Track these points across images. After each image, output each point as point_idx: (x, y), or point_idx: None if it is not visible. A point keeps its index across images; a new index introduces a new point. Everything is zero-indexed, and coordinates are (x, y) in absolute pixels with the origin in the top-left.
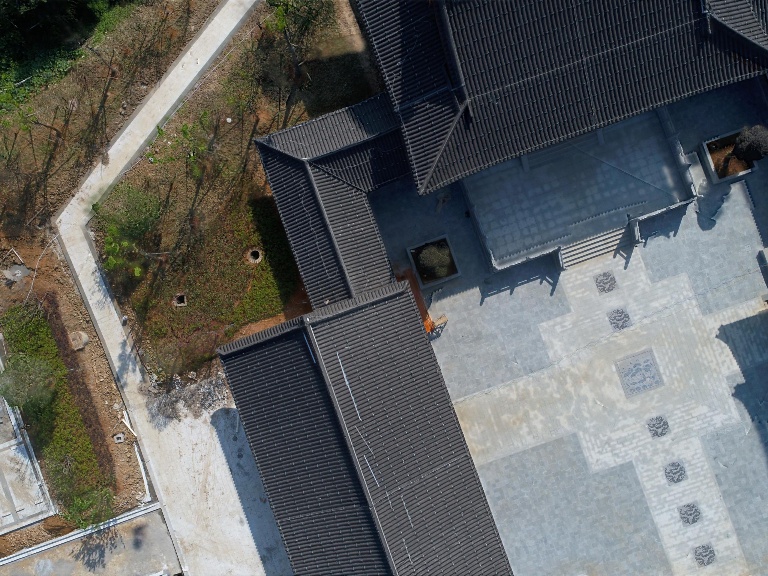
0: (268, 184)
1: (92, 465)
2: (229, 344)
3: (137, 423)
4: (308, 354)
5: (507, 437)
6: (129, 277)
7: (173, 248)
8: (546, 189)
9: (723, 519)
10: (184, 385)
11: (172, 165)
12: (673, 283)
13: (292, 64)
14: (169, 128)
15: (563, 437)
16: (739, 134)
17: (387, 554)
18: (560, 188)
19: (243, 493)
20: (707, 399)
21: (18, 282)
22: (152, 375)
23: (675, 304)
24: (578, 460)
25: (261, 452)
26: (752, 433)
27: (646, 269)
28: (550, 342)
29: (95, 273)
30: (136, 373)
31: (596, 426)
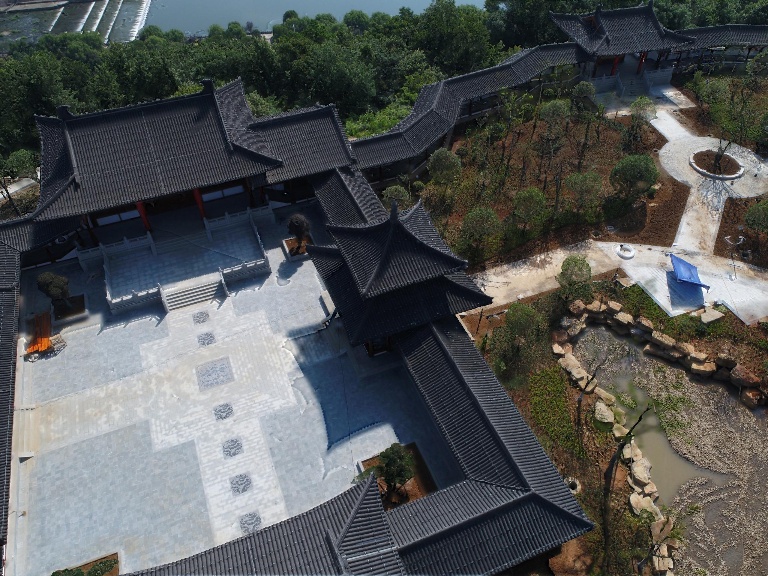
0: None
1: None
2: None
3: None
4: None
5: (85, 426)
6: None
7: None
8: (166, 264)
9: (273, 487)
10: None
11: None
12: (253, 316)
13: None
14: None
15: (136, 424)
16: None
17: None
18: (176, 263)
19: None
20: (269, 389)
21: None
22: None
23: (252, 328)
24: (144, 442)
25: None
26: (306, 413)
27: (234, 309)
28: (146, 356)
29: None
30: None
31: (168, 414)
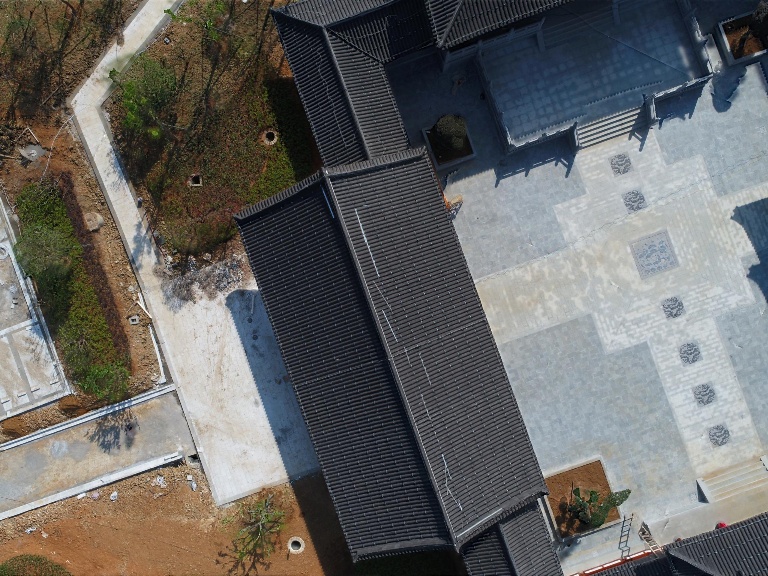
0: (283, 66)
1: (107, 344)
2: (246, 209)
3: (152, 305)
4: (327, 209)
5: (522, 318)
6: (144, 156)
7: (188, 128)
8: (562, 69)
9: (738, 399)
10: (199, 267)
11: (187, 45)
12: (688, 165)
13: None
14: (184, 9)
15: (578, 318)
16: (756, 8)
17: (406, 405)
18: (576, 68)
19: (258, 374)
20: (722, 280)
21: (33, 162)
22: (167, 257)
23: (690, 186)
24: (593, 341)
25: (278, 317)
26: (767, 314)
27: (661, 151)
28: (565, 224)
29: (110, 154)
30: (151, 255)
31: (611, 307)
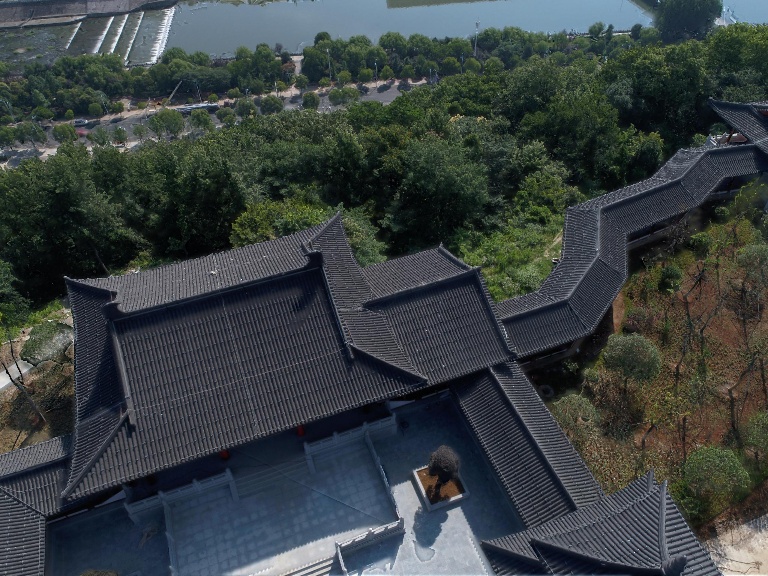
0: None
1: None
2: None
3: None
4: None
5: None
6: None
7: None
8: (253, 518)
9: None
10: None
11: None
12: None
13: (40, 411)
14: None
15: None
16: None
17: None
18: (268, 517)
19: None
20: None
21: None
22: None
23: None
24: None
25: None
26: None
27: None
28: None
29: None
30: None
31: None
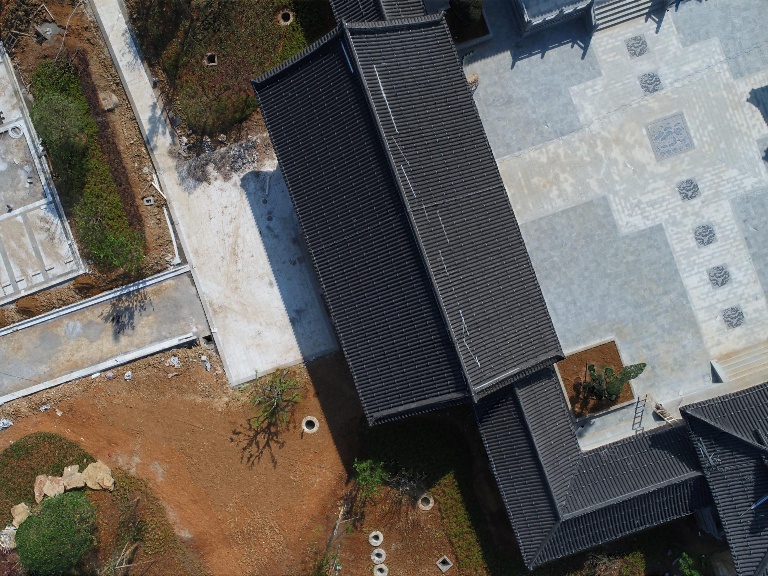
0: None
1: (122, 222)
2: (264, 74)
3: (167, 186)
4: (345, 64)
5: (537, 200)
6: (160, 34)
7: (204, 6)
8: None
9: (752, 281)
10: (214, 148)
11: None
12: (704, 47)
13: None
14: None
15: (593, 200)
16: None
17: (424, 256)
18: None
19: (273, 255)
20: (737, 162)
21: (49, 39)
22: (182, 138)
23: (706, 68)
24: (608, 223)
25: (295, 182)
26: None
27: (678, 33)
28: (581, 105)
29: (125, 34)
30: (166, 136)
31: (626, 189)
